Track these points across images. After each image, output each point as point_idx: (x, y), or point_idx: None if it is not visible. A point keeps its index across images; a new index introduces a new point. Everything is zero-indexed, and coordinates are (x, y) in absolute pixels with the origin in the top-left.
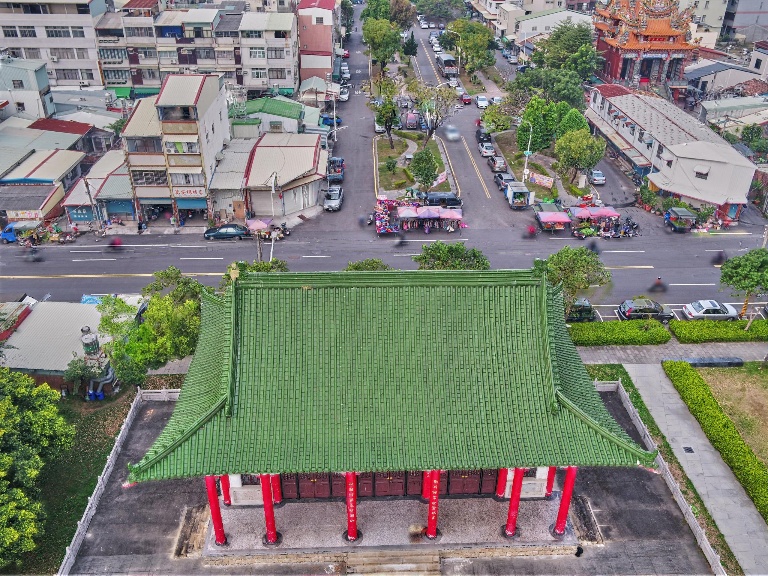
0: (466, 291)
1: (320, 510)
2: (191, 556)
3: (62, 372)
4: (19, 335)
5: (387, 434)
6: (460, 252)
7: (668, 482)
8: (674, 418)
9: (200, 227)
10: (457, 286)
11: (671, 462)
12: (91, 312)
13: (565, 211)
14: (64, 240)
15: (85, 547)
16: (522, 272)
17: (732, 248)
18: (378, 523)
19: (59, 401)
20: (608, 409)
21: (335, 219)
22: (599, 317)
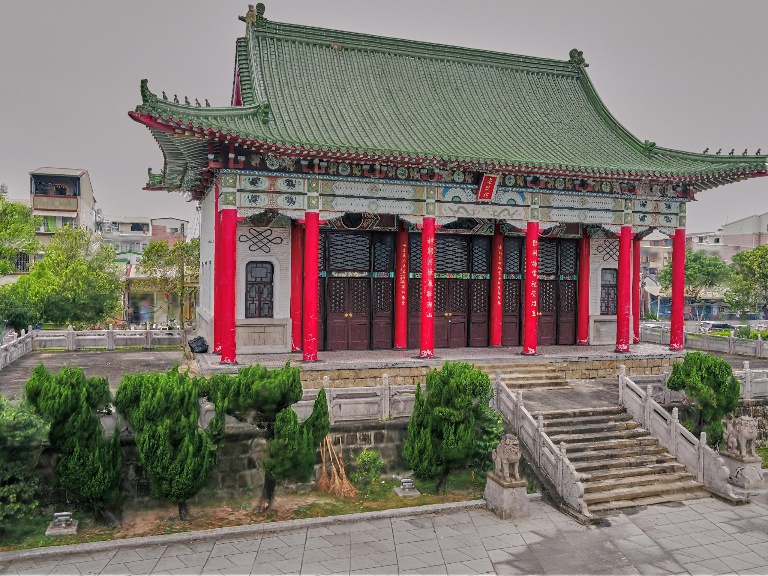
0: (509, 74)
1: (363, 352)
2: None
3: None
4: None
5: None
6: None
7: (742, 350)
8: None
9: (62, 329)
10: (500, 68)
11: None
12: None
13: None
14: None
15: None
16: (560, 61)
17: (658, 261)
18: None
19: None
20: None
21: None
22: None
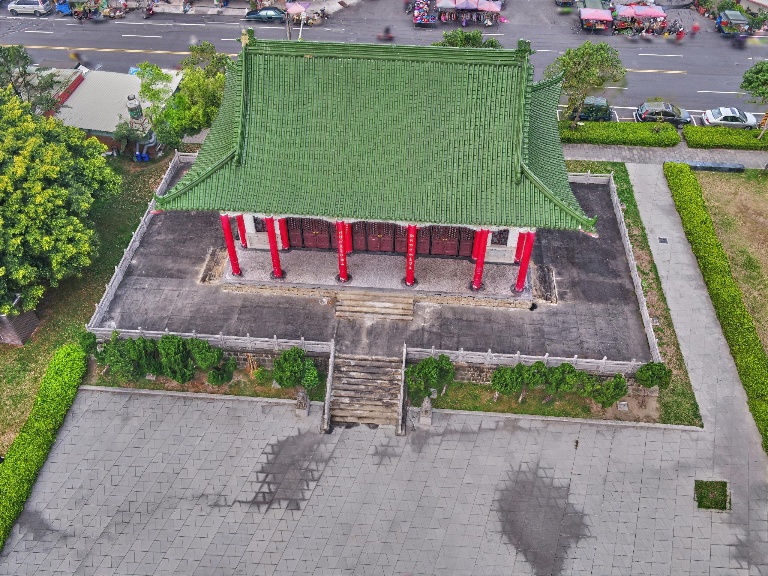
0: (453, 68)
1: (320, 257)
2: (213, 283)
3: (112, 134)
4: (74, 99)
5: (369, 190)
6: (477, 40)
7: (629, 261)
8: (659, 213)
9: (242, 9)
10: (445, 62)
11: (643, 249)
12: (137, 82)
13: (612, 10)
14: (114, 15)
15: (131, 270)
16: (506, 52)
17: (761, 53)
18: (367, 271)
19: (111, 160)
20: (595, 199)
21: (375, 7)
22: (616, 118)
